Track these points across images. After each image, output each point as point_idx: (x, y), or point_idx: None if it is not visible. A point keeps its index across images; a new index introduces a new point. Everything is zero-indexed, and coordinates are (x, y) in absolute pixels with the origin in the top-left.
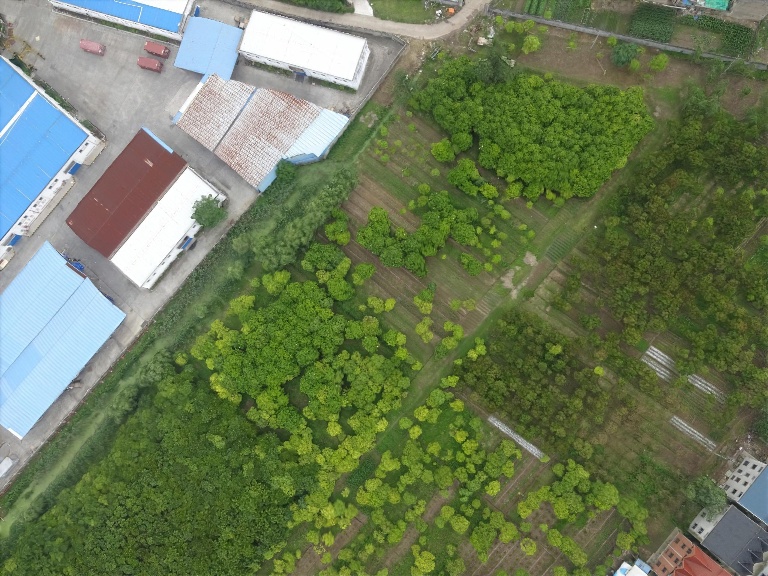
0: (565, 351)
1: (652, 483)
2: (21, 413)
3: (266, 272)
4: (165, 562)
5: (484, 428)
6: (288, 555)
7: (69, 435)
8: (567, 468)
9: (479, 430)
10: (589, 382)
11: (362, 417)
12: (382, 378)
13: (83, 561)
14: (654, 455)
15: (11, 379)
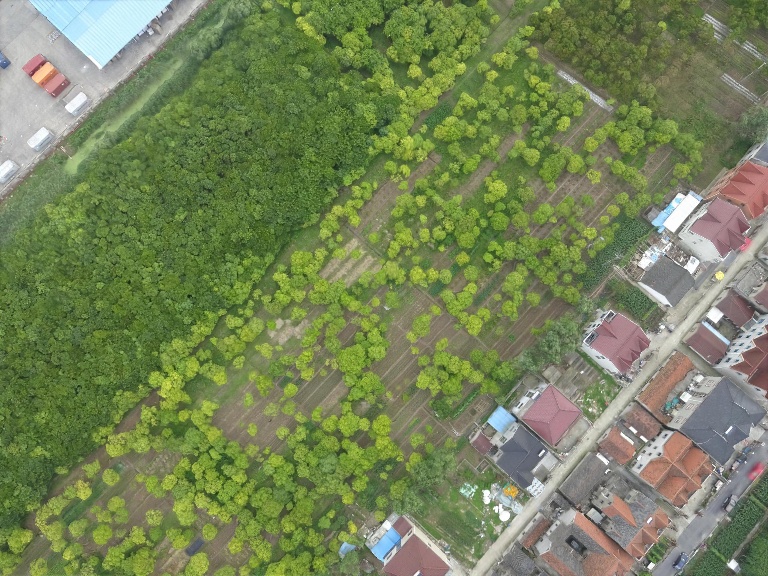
0: (633, 5)
1: (704, 129)
2: (103, 42)
3: None
4: (248, 175)
5: (554, 80)
6: (366, 182)
7: (147, 74)
8: (631, 108)
9: (552, 74)
10: (654, 32)
11: (444, 56)
12: (465, 21)
13: (163, 177)
14: (706, 106)
15: (93, 10)
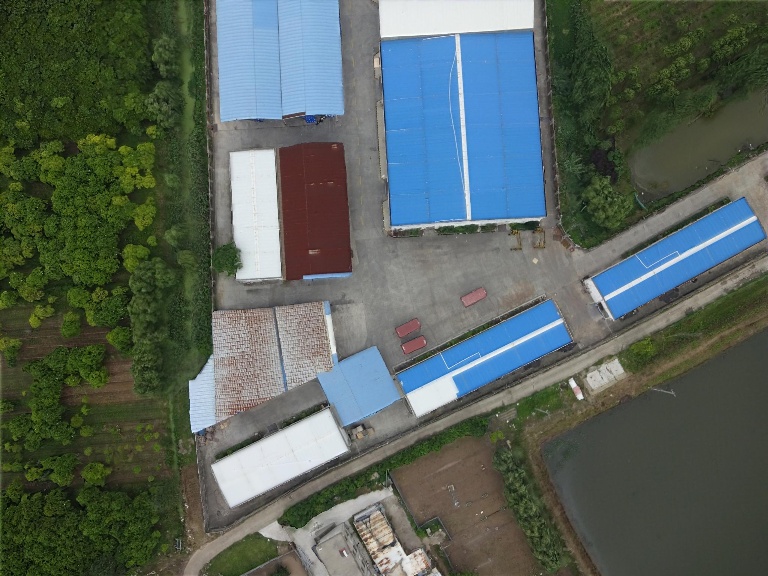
0: None
1: None
2: None
3: (155, 256)
4: None
5: None
6: None
7: None
8: None
9: None
10: None
11: None
12: None
13: None
14: None
15: None
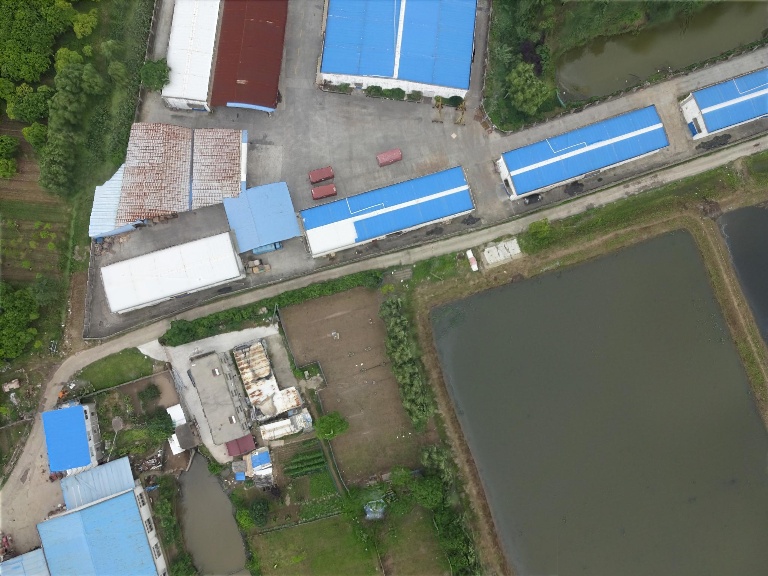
0: None
1: None
2: None
3: None
4: None
5: None
6: None
7: None
8: None
9: None
10: None
11: None
12: None
13: None
14: None
15: None
